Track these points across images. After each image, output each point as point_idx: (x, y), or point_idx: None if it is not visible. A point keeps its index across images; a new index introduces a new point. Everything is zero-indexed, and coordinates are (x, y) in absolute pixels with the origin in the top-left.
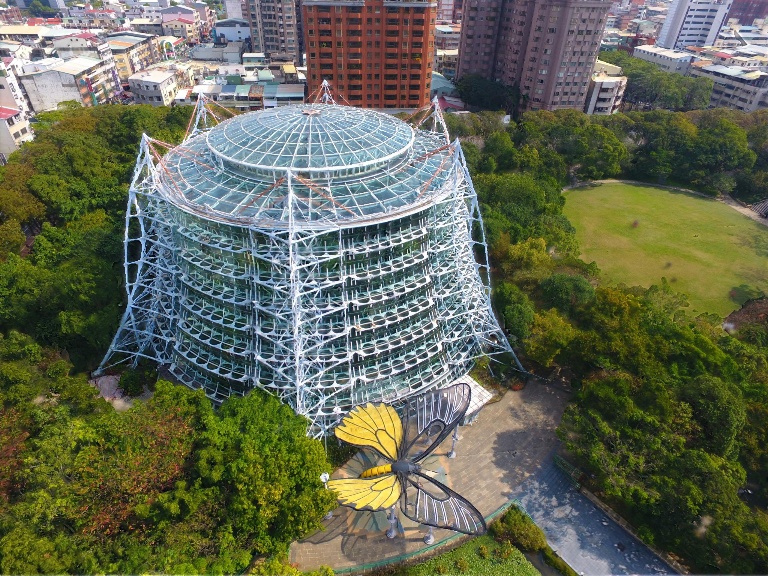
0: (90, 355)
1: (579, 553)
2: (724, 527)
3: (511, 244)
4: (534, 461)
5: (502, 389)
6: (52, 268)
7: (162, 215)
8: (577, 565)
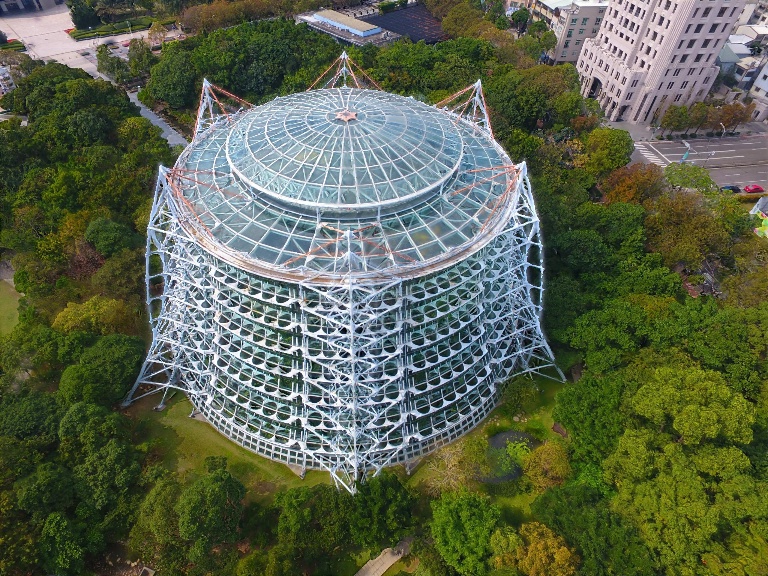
0: None
1: None
2: (157, 141)
3: (97, 336)
4: None
5: None
6: None
7: None
8: None
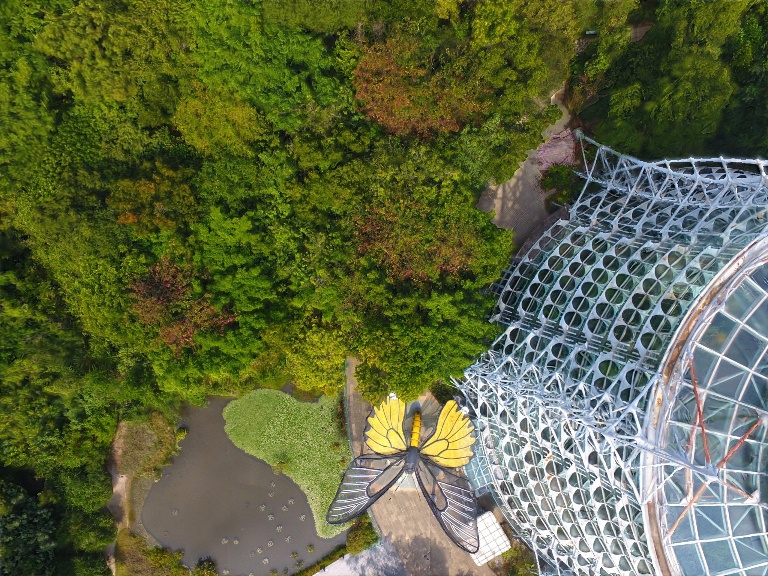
0: (606, 117)
1: (341, 575)
2: None
3: None
4: (417, 573)
5: (503, 573)
6: (766, 17)
7: (759, 213)
8: (333, 569)
